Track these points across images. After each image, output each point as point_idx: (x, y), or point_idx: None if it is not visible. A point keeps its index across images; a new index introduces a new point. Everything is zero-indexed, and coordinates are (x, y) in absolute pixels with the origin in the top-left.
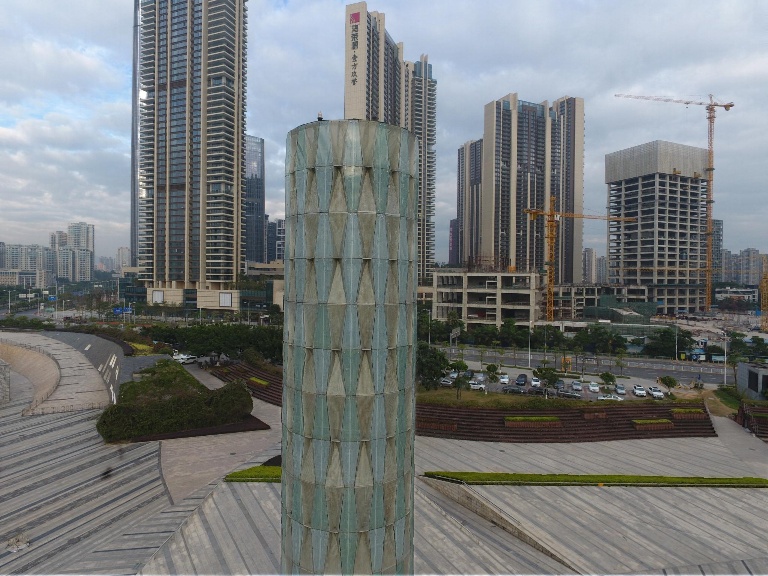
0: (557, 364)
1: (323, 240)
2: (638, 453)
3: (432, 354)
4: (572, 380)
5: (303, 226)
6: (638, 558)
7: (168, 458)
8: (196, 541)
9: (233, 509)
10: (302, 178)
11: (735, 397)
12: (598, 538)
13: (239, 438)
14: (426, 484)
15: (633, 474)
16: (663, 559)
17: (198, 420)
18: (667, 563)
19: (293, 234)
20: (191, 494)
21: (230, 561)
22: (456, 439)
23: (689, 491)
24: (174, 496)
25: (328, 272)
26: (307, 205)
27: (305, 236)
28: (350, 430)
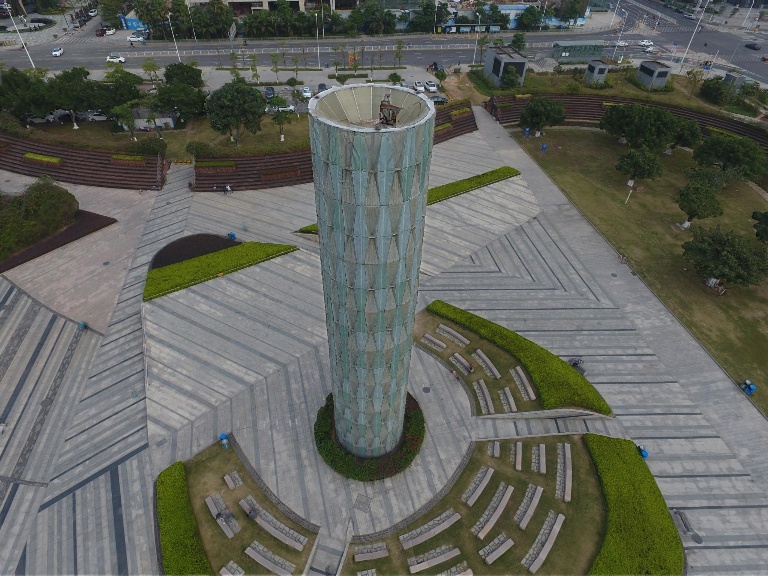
0: (345, 62)
1: (382, 223)
2: (435, 161)
3: (252, 97)
4: (363, 80)
5: (360, 212)
6: (457, 253)
7: (38, 292)
8: (170, 359)
9: (176, 322)
10: (358, 176)
11: (483, 81)
12: (434, 248)
13: (93, 243)
14: (305, 239)
15: (437, 184)
16: (469, 249)
17: (27, 238)
18: (471, 251)
19: (347, 216)
20: (110, 320)
21: (211, 361)
22: (303, 184)
23: (475, 193)
24: (95, 328)
25: (387, 244)
26: (367, 199)
27: (366, 223)
28: (397, 321)
